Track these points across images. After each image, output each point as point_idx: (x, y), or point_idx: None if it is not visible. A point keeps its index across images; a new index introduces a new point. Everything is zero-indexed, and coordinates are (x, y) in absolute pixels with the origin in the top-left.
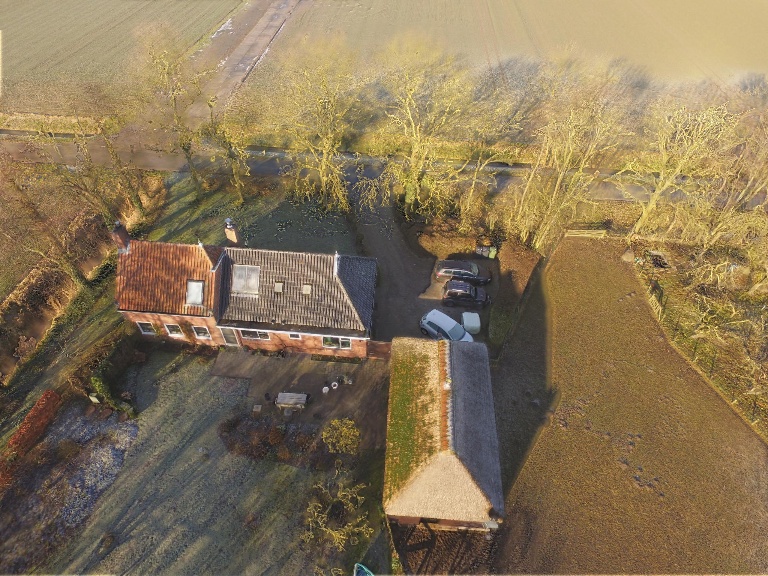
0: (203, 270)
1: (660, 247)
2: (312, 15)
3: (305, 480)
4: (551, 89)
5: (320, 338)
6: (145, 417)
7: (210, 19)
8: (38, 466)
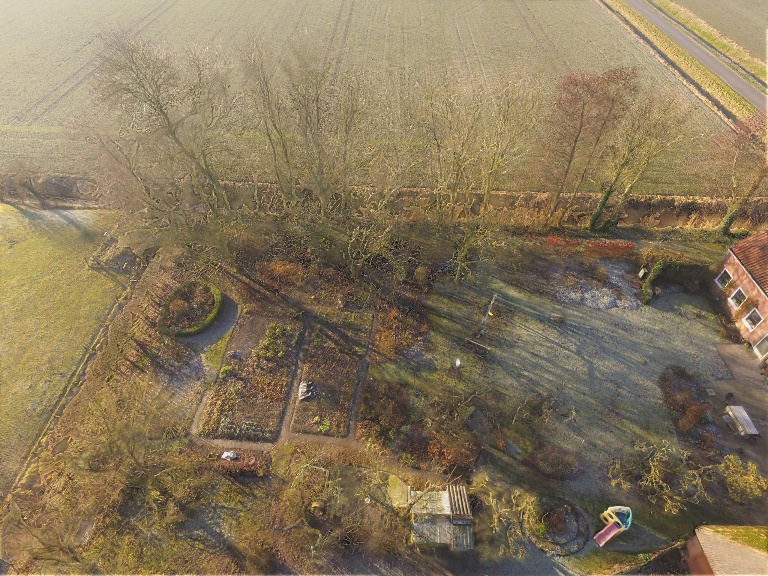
0: None
1: None
2: None
3: None
4: None
5: None
6: (648, 310)
7: None
8: (581, 265)
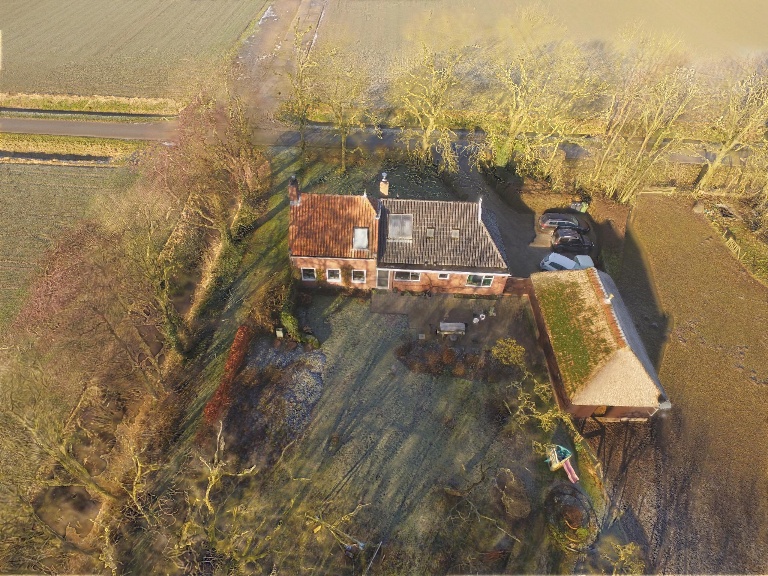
0: (367, 218)
1: (723, 200)
2: (347, 3)
3: (482, 390)
4: (591, 68)
5: (466, 277)
6: (327, 347)
7: (251, 7)
8: (249, 388)
